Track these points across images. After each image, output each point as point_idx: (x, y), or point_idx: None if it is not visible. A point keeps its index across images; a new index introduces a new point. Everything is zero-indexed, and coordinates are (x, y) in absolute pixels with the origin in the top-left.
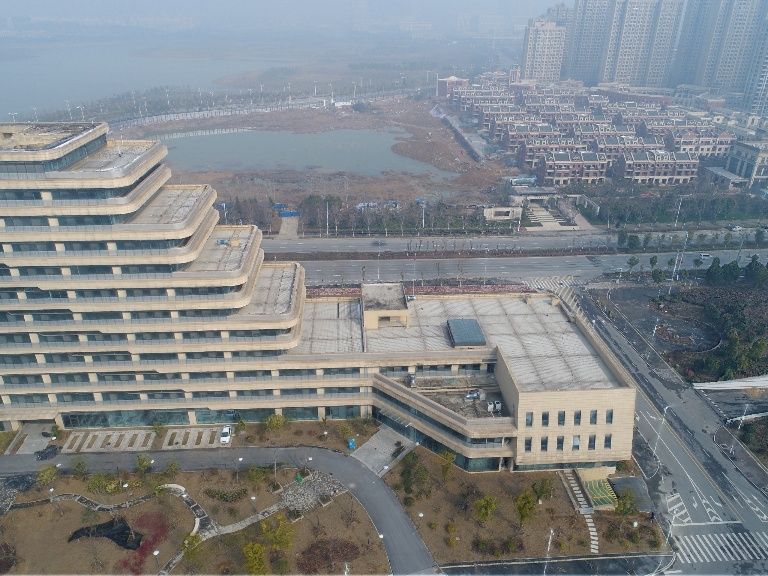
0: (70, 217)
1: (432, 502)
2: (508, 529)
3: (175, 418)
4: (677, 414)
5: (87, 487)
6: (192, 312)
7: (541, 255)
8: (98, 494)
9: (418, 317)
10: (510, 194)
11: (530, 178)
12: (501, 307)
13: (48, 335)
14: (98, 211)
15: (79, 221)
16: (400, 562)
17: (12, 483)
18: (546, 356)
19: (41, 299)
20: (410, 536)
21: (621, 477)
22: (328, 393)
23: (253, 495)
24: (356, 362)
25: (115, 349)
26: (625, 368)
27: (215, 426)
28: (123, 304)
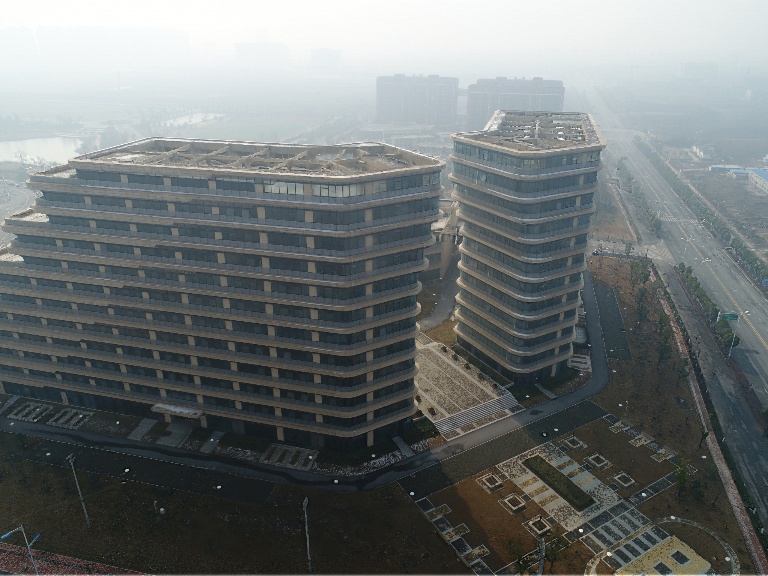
0: None
1: None
2: None
3: None
4: None
5: None
6: None
7: None
8: None
9: None
10: None
11: None
12: None
13: None
14: None
15: None
16: None
17: None
18: None
19: None
20: None
21: None
22: None
23: None
24: None
25: None
26: None
27: None
28: None
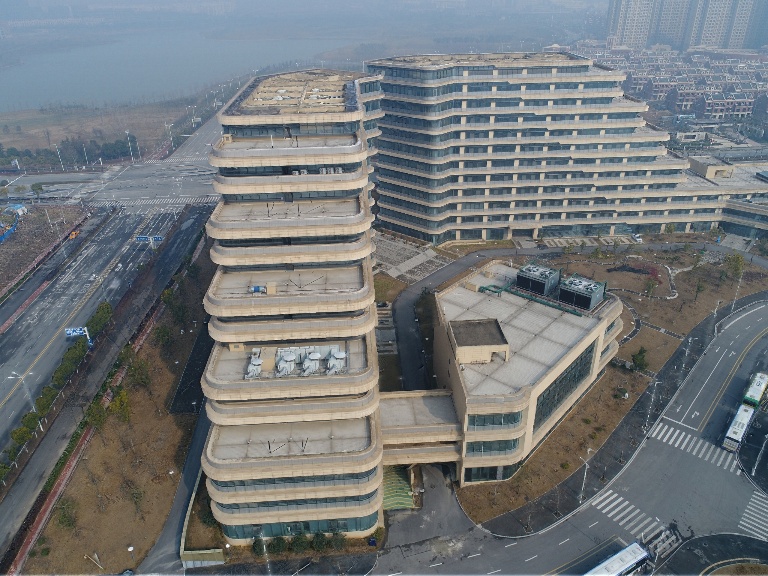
0: (589, 99)
1: None
2: None
3: (602, 231)
4: None
5: (587, 257)
6: (635, 159)
7: (740, 160)
8: (597, 259)
9: None
10: (688, 124)
11: (692, 114)
12: None
13: (550, 174)
14: (608, 95)
15: (593, 102)
16: None
17: (541, 257)
18: None
19: (555, 151)
20: None
21: None
22: (696, 213)
23: (684, 258)
24: (720, 191)
25: (587, 183)
26: None
27: (625, 236)
28: (601, 153)
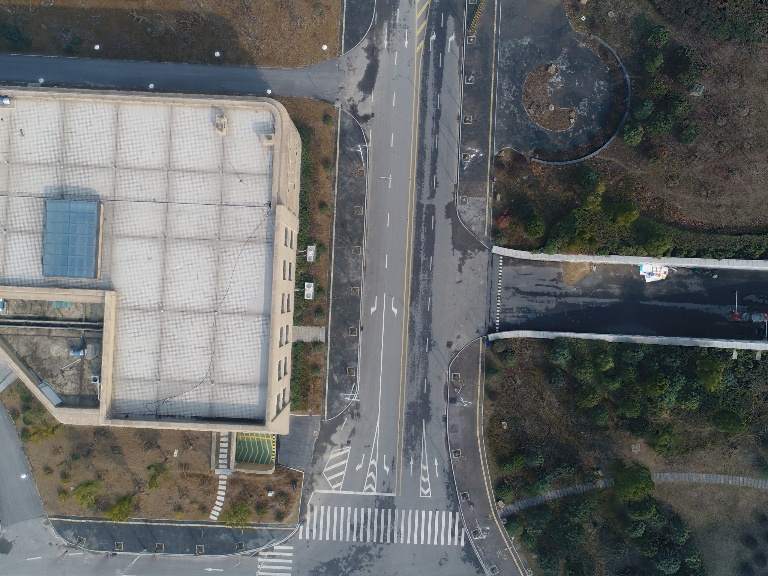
0: None
1: (52, 439)
2: (129, 484)
3: None
4: (432, 307)
5: None
6: None
7: None
8: None
9: (9, 164)
10: None
11: None
12: (167, 141)
13: None
14: None
15: None
16: (9, 509)
17: None
18: (189, 311)
19: None
20: (23, 479)
21: (295, 415)
22: None
23: None
24: None
25: None
26: (415, 189)
27: None
28: None
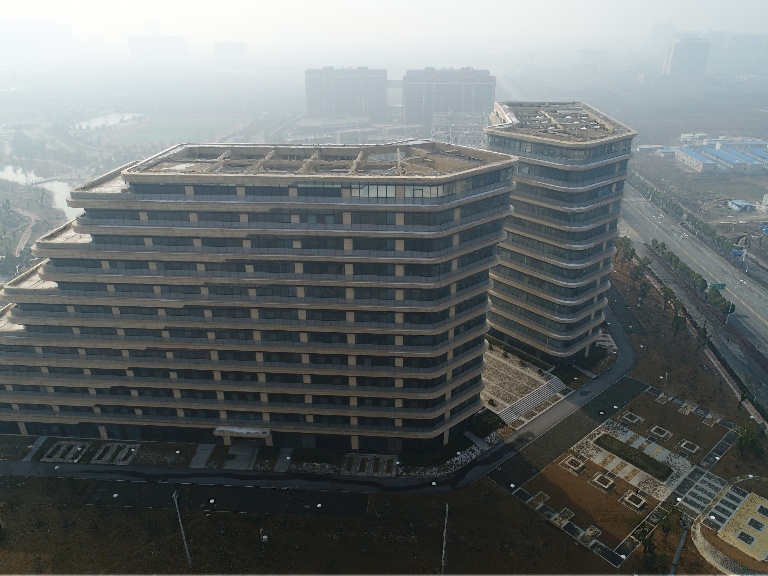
0: None
1: None
2: None
3: None
4: None
5: None
6: None
7: None
8: None
9: None
10: None
11: None
12: None
13: None
14: None
15: None
16: None
17: None
18: None
19: None
20: None
21: None
22: None
23: None
24: None
25: None
26: None
27: None
28: None
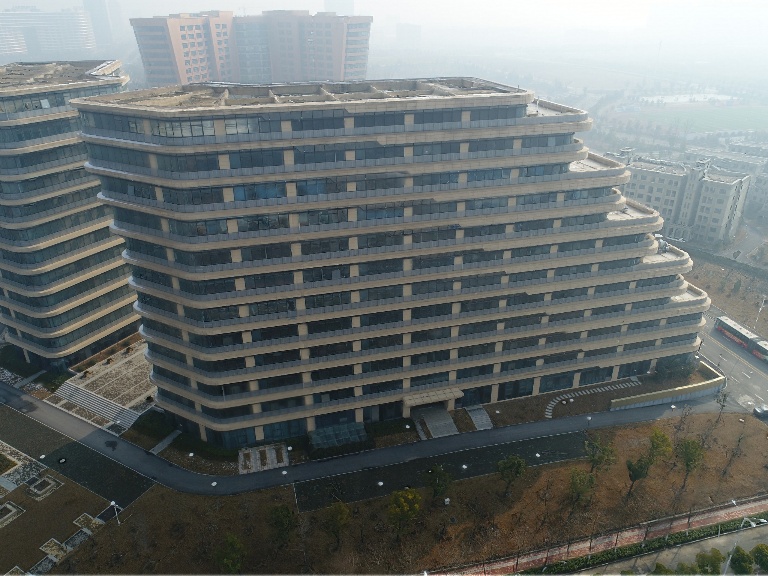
0: None
1: None
2: None
3: None
4: None
5: None
6: None
7: None
8: None
9: None
10: None
11: None
12: None
13: None
14: None
15: None
16: None
17: None
18: None
19: None
20: None
21: None
22: None
23: None
24: None
25: None
26: None
27: None
28: None
